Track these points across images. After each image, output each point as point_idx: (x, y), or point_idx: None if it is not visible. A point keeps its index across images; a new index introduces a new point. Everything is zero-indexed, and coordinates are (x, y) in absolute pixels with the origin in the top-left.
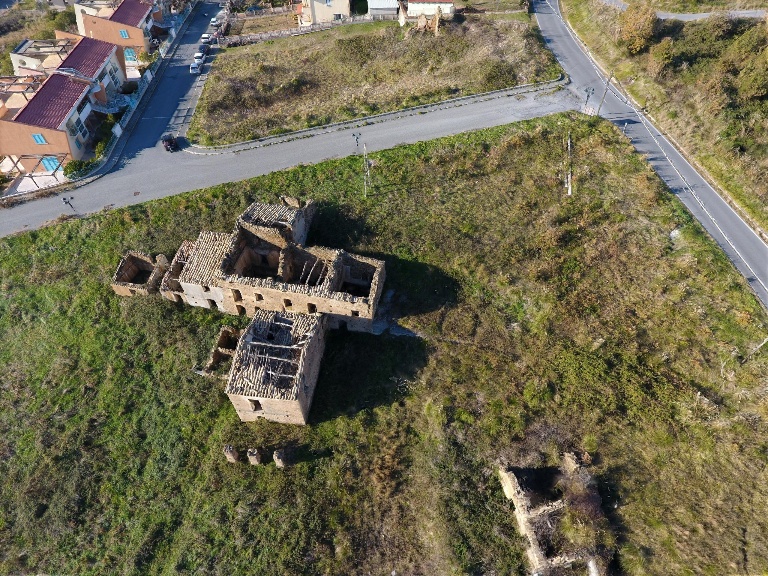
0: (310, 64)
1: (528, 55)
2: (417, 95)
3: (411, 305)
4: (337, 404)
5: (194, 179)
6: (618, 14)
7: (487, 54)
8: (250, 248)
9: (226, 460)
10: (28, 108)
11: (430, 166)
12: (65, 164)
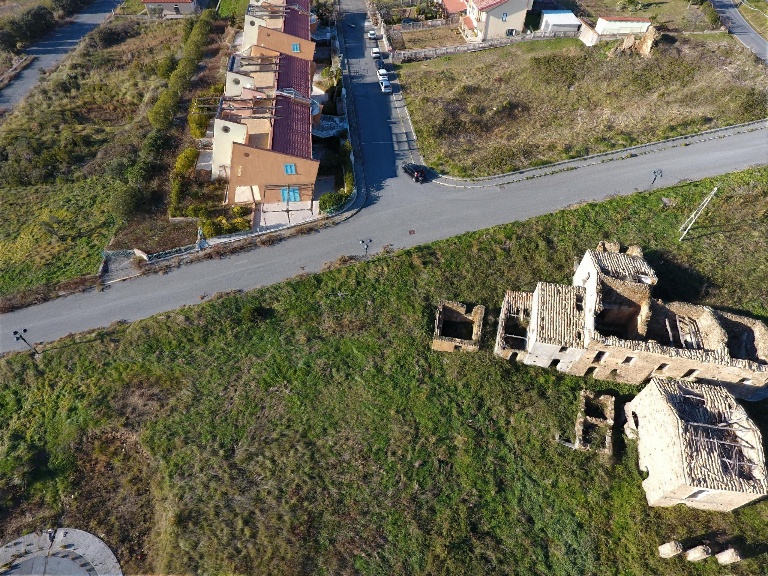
0: (505, 84)
1: None
2: (673, 124)
3: None
4: None
5: (470, 216)
6: None
7: (727, 80)
8: None
9: (657, 555)
10: (275, 135)
11: (733, 206)
12: (304, 195)
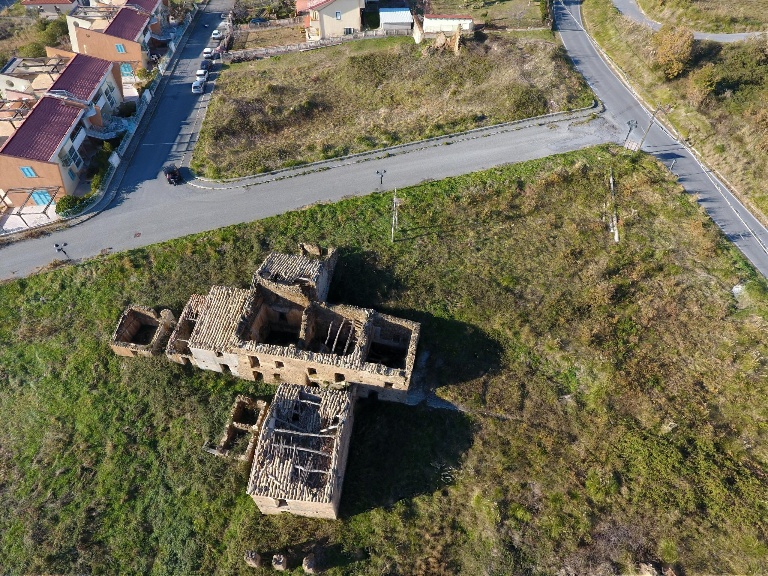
0: (321, 83)
1: (558, 79)
2: (441, 123)
3: (449, 372)
4: (371, 492)
5: (201, 218)
6: (650, 34)
7: (514, 77)
8: (267, 305)
9: (246, 564)
10: (16, 137)
11: (461, 206)
12: (57, 198)
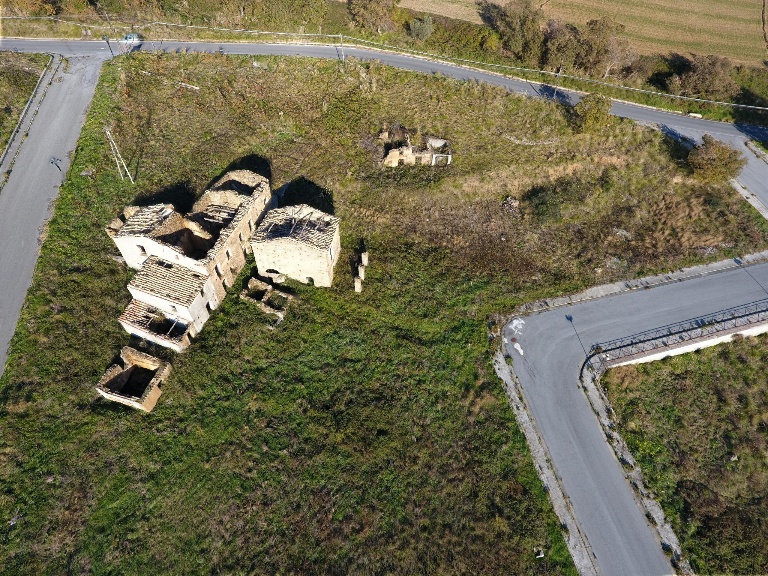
0: None
1: None
2: None
3: None
4: None
5: None
6: None
7: None
8: None
9: (359, 294)
10: None
11: None
12: None
